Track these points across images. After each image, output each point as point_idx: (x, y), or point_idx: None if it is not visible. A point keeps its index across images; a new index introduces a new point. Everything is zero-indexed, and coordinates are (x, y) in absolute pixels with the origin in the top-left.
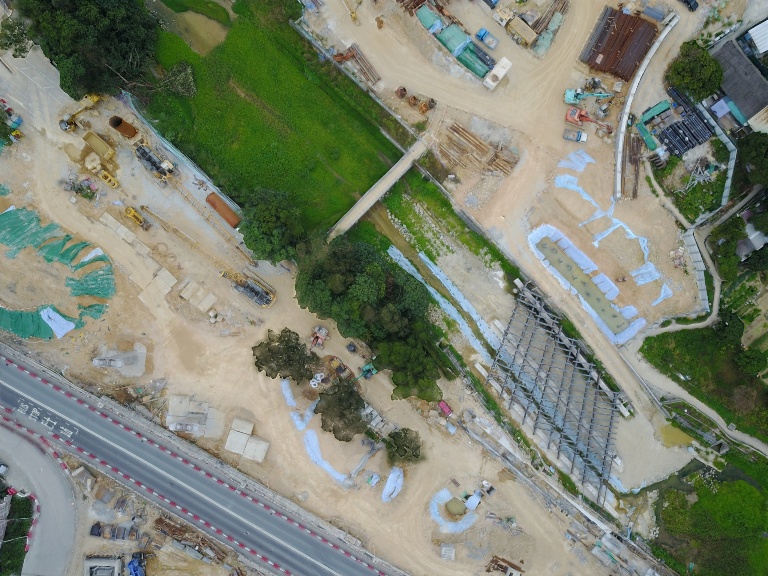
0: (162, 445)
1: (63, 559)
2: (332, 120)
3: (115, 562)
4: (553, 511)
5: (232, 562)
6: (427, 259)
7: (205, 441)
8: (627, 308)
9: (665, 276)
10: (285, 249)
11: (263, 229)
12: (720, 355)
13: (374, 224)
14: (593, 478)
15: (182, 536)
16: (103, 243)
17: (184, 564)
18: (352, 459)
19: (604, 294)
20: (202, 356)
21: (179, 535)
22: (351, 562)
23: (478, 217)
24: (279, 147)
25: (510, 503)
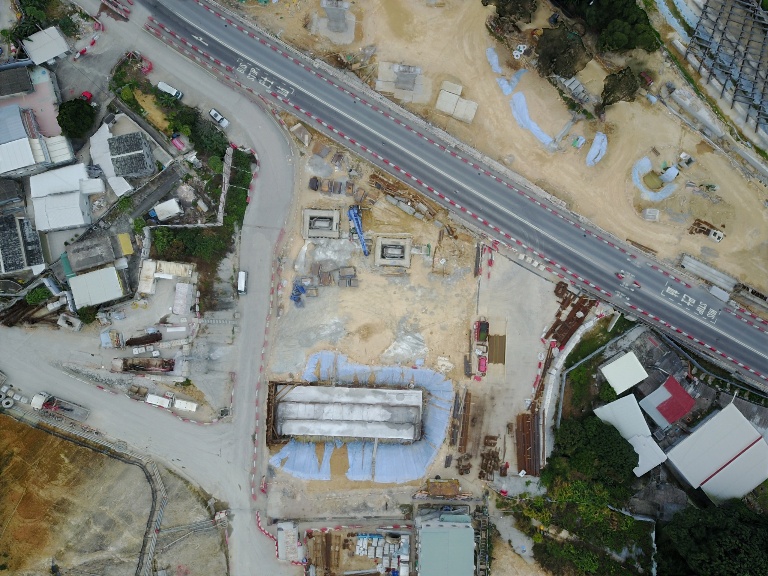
0: (374, 106)
1: (282, 212)
2: None
3: (333, 212)
4: (752, 181)
5: (442, 219)
6: None
7: (413, 106)
8: None
9: None
10: None
11: None
12: None
13: None
14: None
15: (395, 191)
16: None
17: (396, 220)
18: (557, 122)
19: None
20: (410, 24)
21: (392, 190)
22: (557, 222)
23: None
24: None
25: (710, 172)
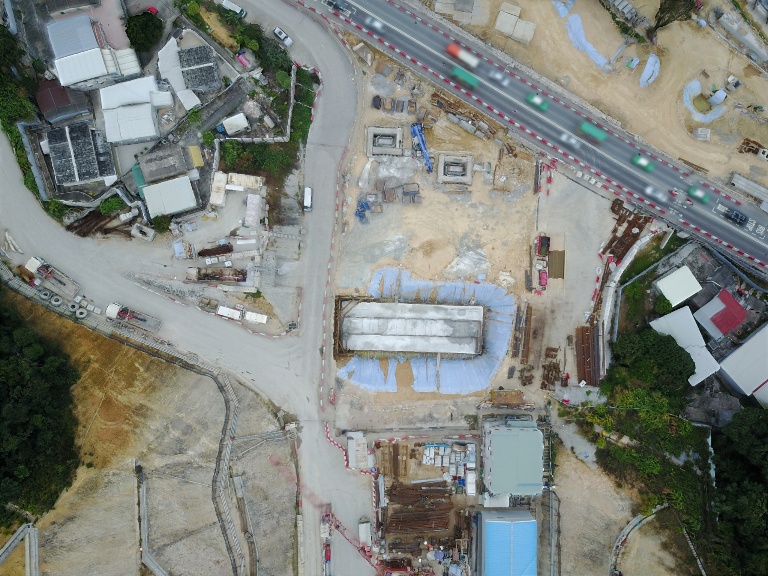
0: (435, 26)
1: (345, 130)
2: None
3: (397, 130)
4: None
5: (502, 138)
6: None
7: (472, 28)
8: None
9: None
10: None
11: None
12: None
13: None
14: None
15: (456, 110)
16: None
17: (457, 138)
18: (612, 44)
19: None
20: None
21: (454, 109)
22: (613, 141)
23: None
24: None
25: (757, 94)
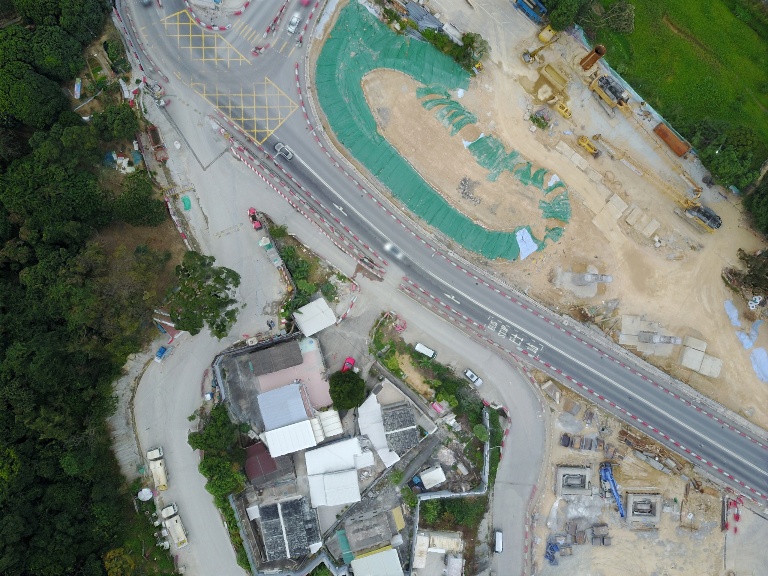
0: (621, 361)
1: (533, 468)
2: (762, 55)
3: (586, 470)
4: None
5: (688, 473)
6: None
7: (656, 359)
8: None
9: None
10: (751, 173)
11: (740, 152)
12: None
13: None
14: None
15: (644, 447)
16: (559, 170)
17: (644, 474)
18: None
19: None
20: (651, 278)
21: (641, 446)
22: None
23: None
24: (713, 81)
25: None
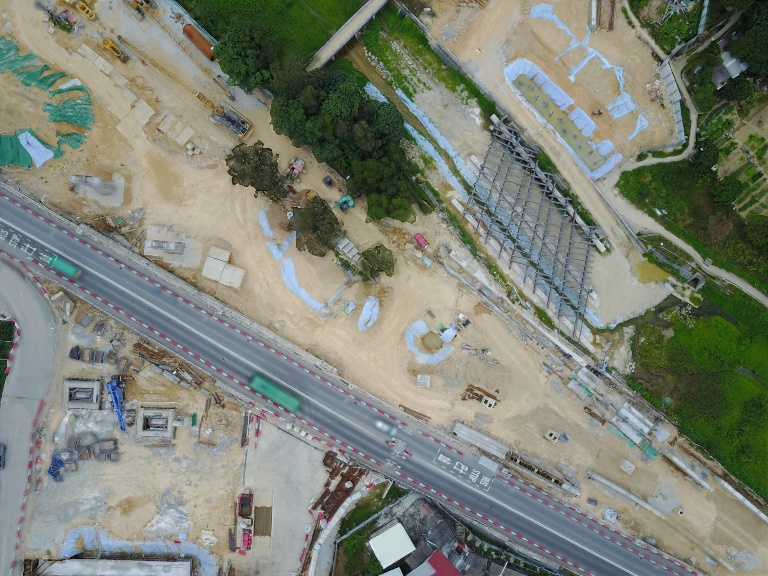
0: (140, 272)
1: (43, 382)
2: None
3: (94, 384)
4: (529, 343)
5: (209, 387)
6: (404, 96)
7: (183, 270)
8: (603, 143)
9: (641, 107)
10: (260, 72)
11: (237, 48)
12: (696, 188)
13: (351, 61)
14: (569, 312)
15: (160, 360)
16: (81, 74)
17: (162, 388)
18: (328, 288)
19: (581, 131)
20: (179, 187)
21: (157, 359)
22: (327, 389)
23: (454, 50)
24: None
25: (486, 335)
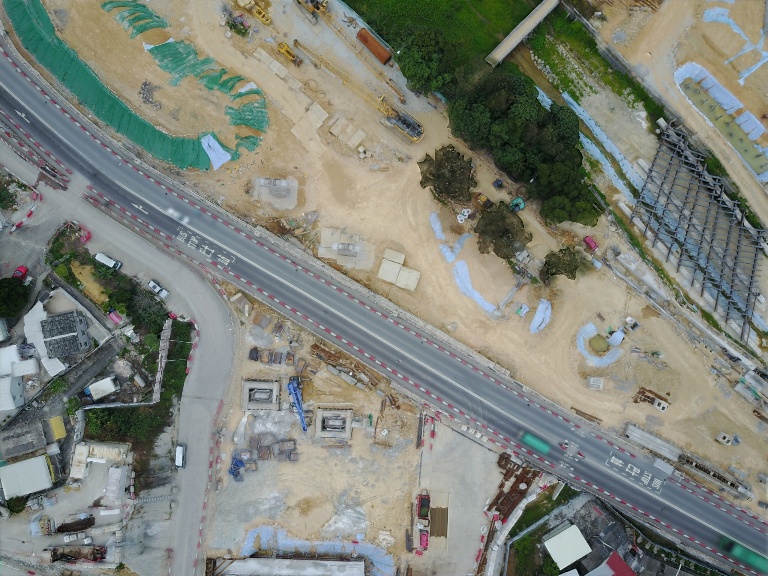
0: (316, 274)
1: (222, 382)
2: None
3: (273, 384)
4: (697, 347)
5: (384, 389)
6: (570, 99)
7: (356, 272)
8: None
9: None
10: (441, 76)
11: (423, 53)
12: None
13: (517, 65)
14: (737, 315)
15: (337, 362)
16: (256, 78)
17: (338, 390)
18: (501, 290)
19: (747, 134)
20: (353, 189)
21: (334, 361)
22: (500, 391)
23: (624, 54)
24: None
25: (655, 338)
